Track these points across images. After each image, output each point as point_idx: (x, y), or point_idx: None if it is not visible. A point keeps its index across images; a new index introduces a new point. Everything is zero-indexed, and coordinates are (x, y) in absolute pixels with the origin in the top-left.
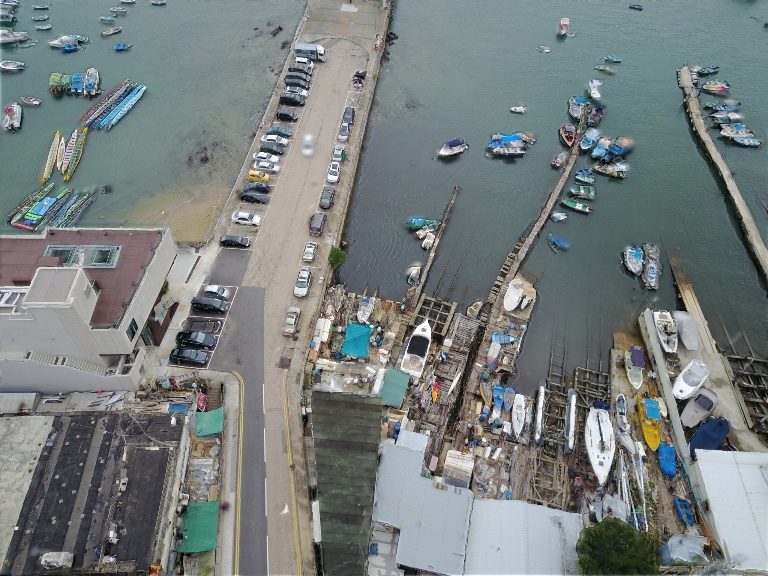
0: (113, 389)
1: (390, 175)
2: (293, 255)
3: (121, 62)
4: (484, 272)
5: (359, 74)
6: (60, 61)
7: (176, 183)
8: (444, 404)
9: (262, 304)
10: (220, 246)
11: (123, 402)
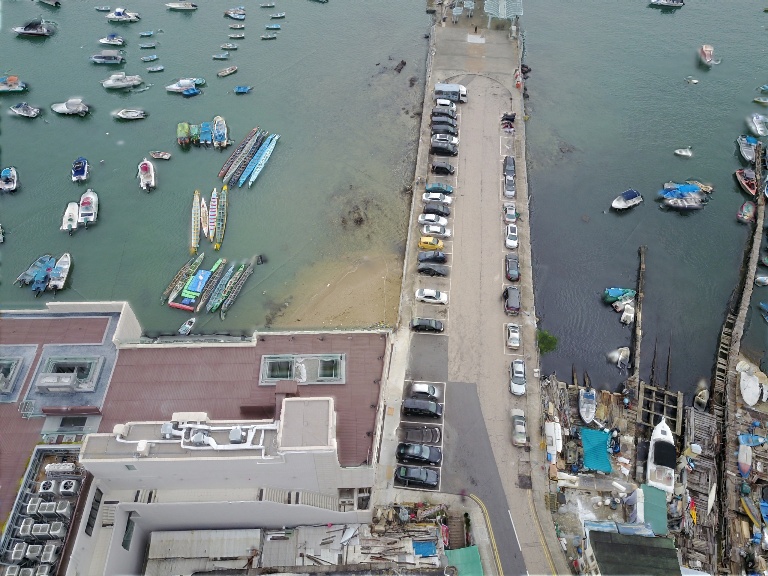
0: (345, 522)
1: (561, 233)
2: (494, 340)
3: (244, 107)
4: (694, 350)
5: (508, 117)
6: (178, 107)
7: (335, 249)
8: (706, 526)
9: (478, 404)
10: (411, 331)
11: (359, 538)
